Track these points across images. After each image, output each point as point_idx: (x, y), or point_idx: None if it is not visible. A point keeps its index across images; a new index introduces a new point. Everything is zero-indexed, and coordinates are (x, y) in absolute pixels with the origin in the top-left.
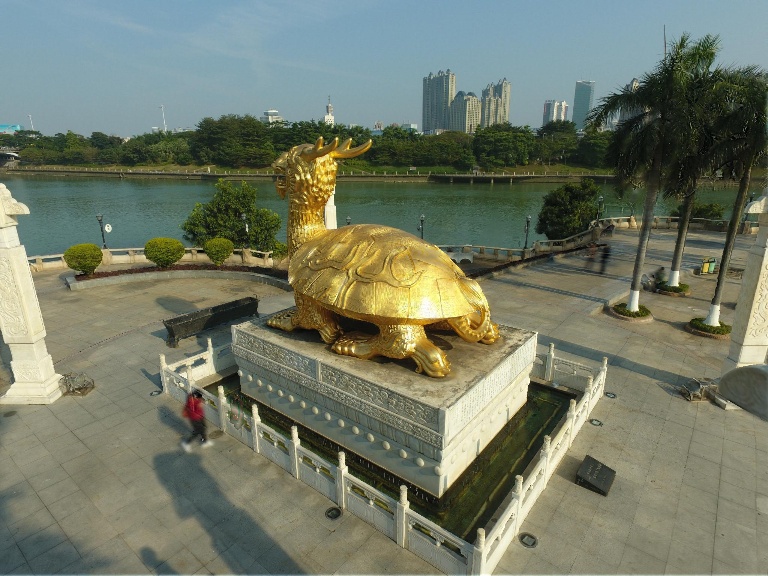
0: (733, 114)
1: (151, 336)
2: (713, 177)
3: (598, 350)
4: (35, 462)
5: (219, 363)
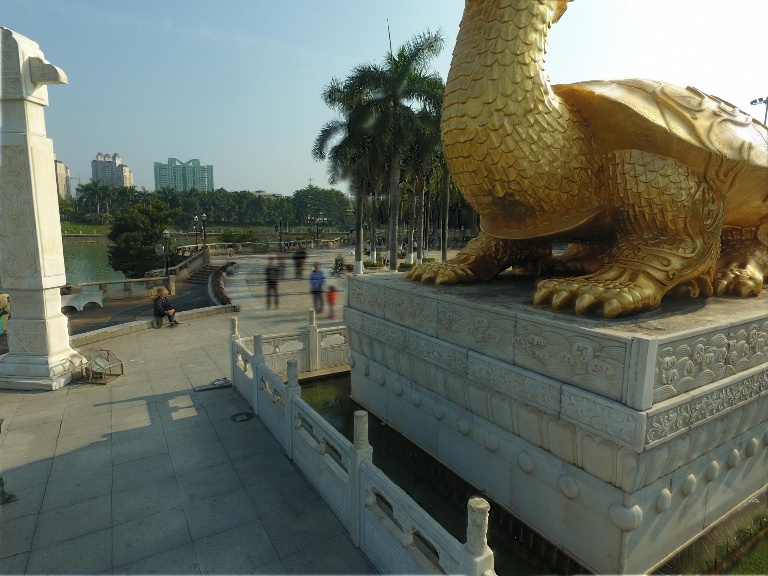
0: (424, 114)
1: None
2: None
3: None
4: None
5: None
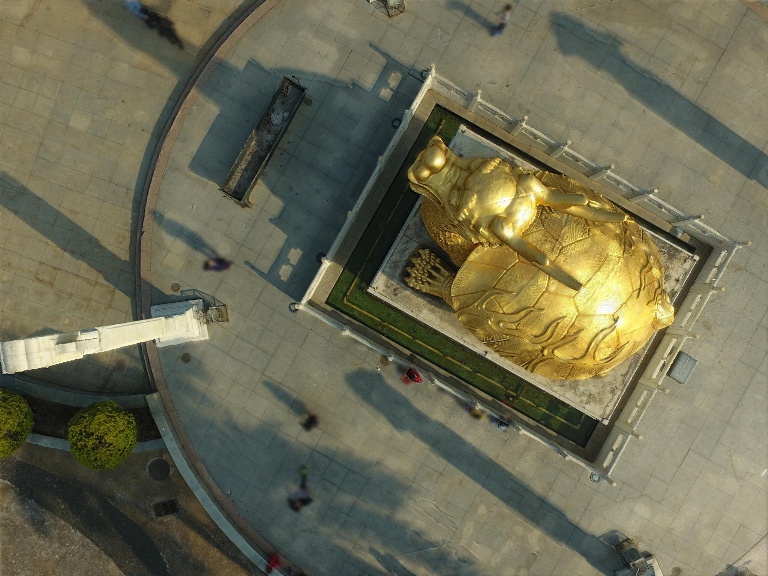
0: None
1: (197, 178)
2: None
3: (746, 140)
4: (267, 412)
5: (332, 256)
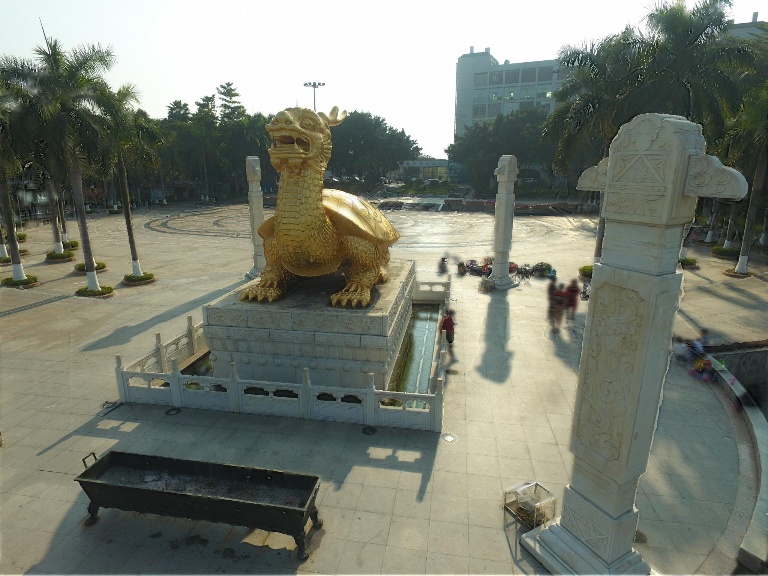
0: (86, 112)
1: None
2: (20, 167)
3: (206, 294)
4: None
5: None
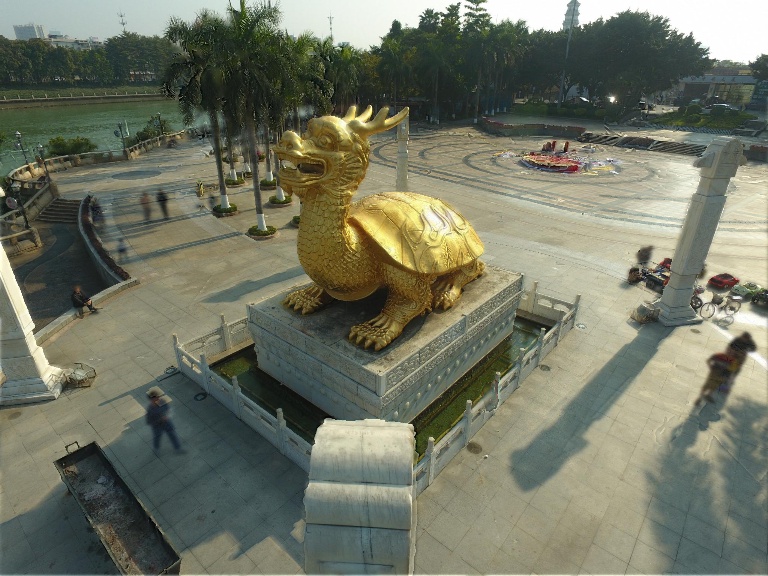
0: (270, 64)
1: None
2: None
3: None
4: None
5: None
